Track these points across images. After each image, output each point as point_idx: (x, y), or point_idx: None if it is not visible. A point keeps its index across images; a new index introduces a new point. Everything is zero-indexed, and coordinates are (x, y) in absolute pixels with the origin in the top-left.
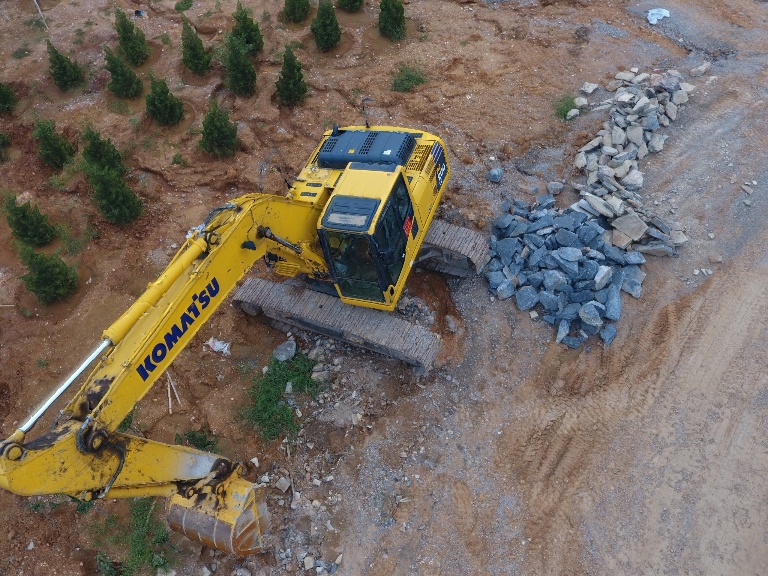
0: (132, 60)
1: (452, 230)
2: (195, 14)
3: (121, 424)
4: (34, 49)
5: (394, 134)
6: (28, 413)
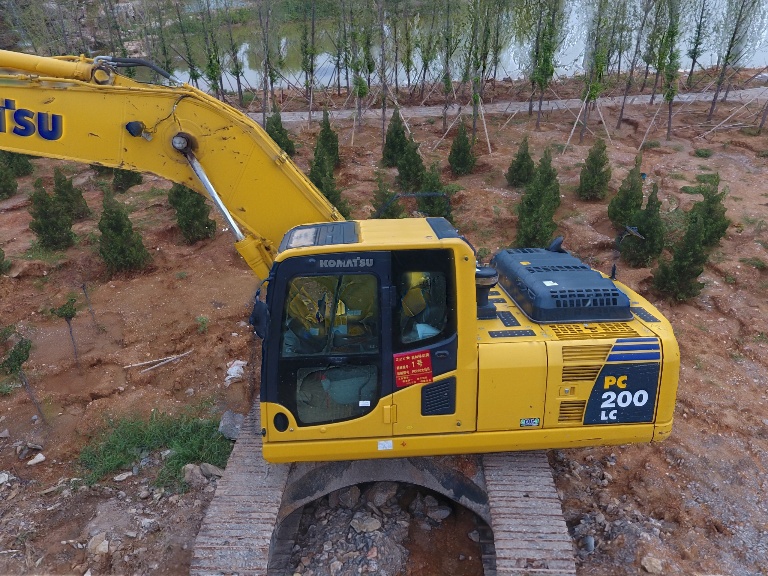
0: (580, 191)
1: (543, 504)
2: (692, 198)
3: (64, 307)
4: (533, 158)
5: (602, 279)
6: (125, 289)
